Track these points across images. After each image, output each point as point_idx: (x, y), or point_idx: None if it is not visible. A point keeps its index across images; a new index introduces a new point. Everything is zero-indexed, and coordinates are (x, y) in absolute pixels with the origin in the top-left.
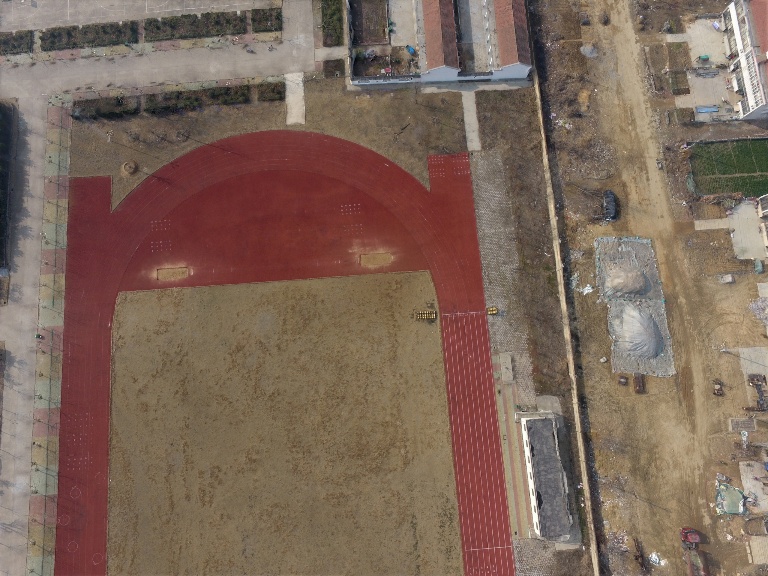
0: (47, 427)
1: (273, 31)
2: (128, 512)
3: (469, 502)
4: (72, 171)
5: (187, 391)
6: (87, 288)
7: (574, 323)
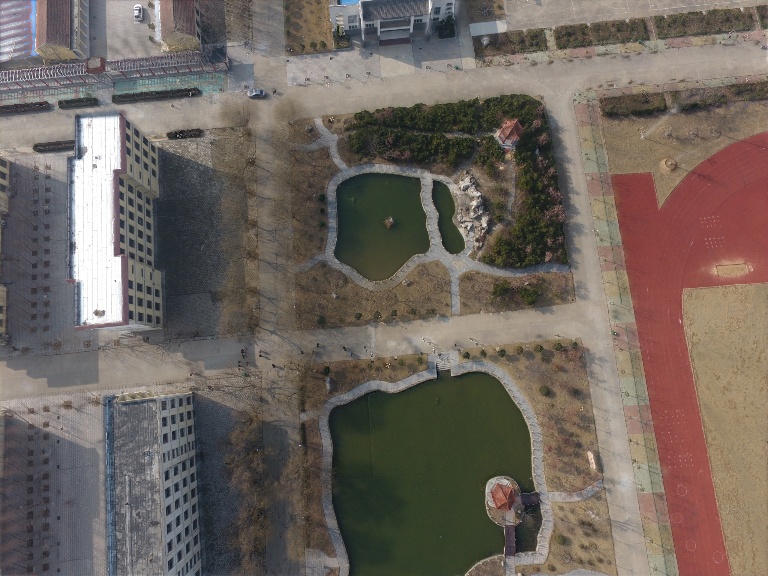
0: (640, 424)
1: None
2: (738, 510)
3: None
4: (612, 168)
5: None
6: (651, 285)
7: None
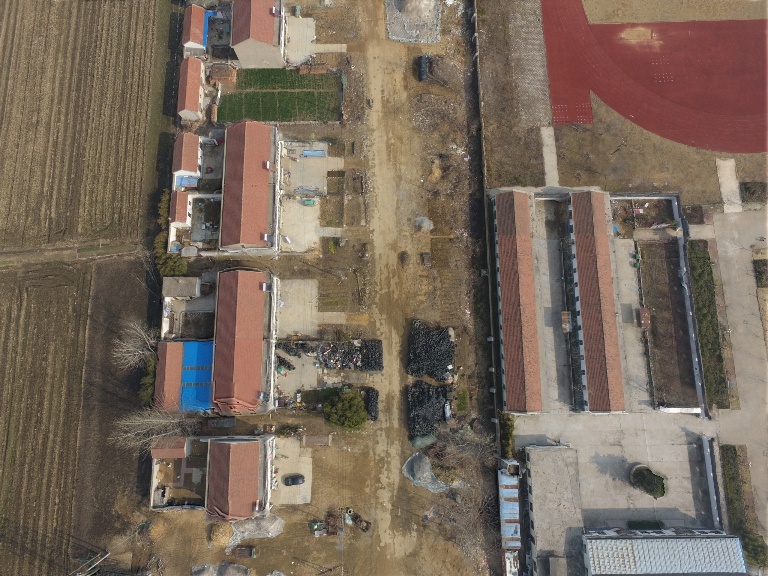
0: None
1: (762, 260)
2: None
3: None
4: None
5: None
6: None
7: None
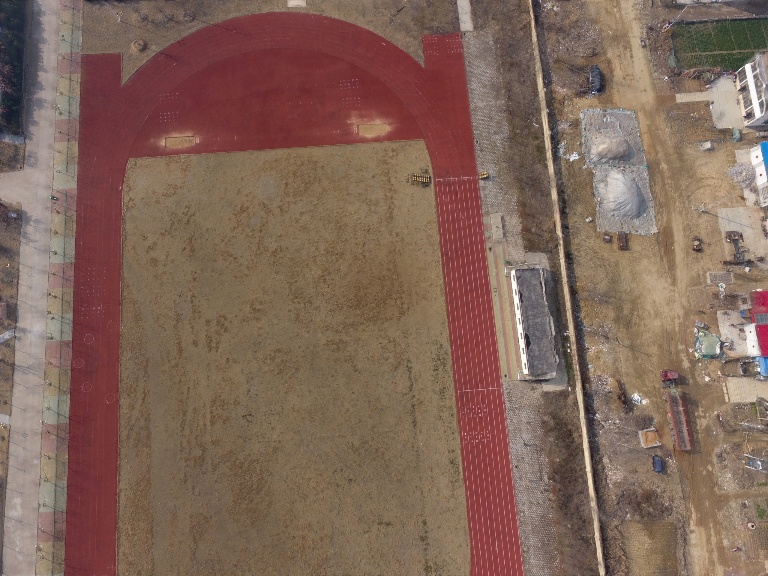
0: (62, 280)
1: None
2: (139, 356)
3: (461, 348)
4: (84, 48)
5: (194, 248)
6: (99, 154)
7: (561, 187)
